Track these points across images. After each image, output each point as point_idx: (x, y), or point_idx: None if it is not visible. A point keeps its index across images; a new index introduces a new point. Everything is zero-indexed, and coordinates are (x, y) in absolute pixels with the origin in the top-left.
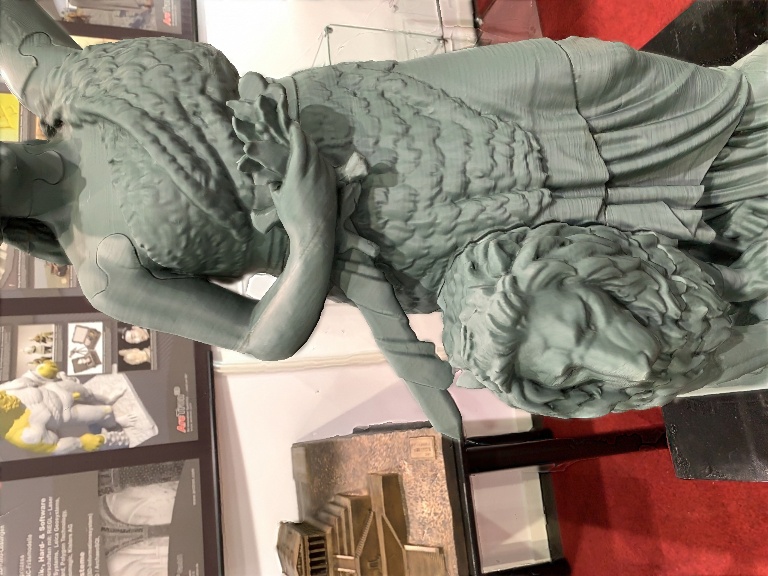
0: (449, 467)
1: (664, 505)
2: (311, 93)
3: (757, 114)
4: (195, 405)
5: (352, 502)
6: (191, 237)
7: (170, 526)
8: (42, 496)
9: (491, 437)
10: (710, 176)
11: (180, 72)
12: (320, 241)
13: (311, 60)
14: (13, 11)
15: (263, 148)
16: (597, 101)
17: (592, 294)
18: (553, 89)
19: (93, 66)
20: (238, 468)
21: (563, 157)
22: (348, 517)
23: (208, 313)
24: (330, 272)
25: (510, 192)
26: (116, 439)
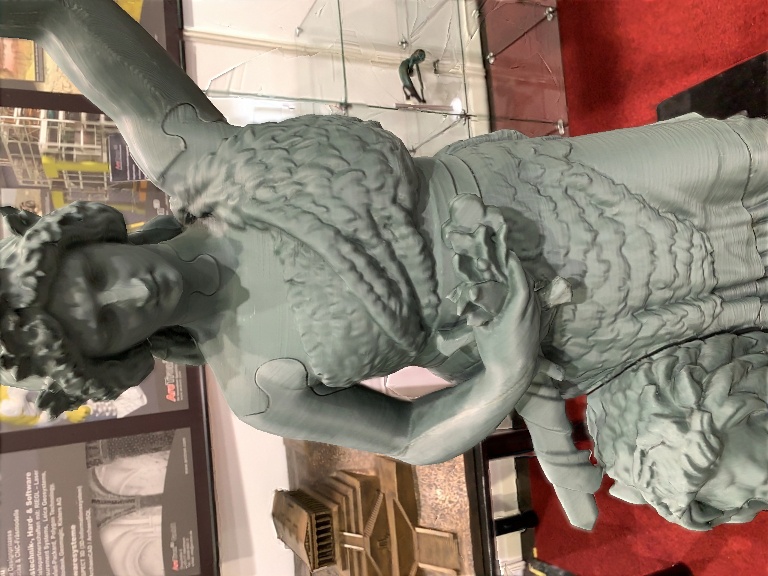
0: (468, 460)
1: None
2: (496, 191)
3: None
4: (184, 373)
5: (361, 484)
6: (374, 364)
7: (163, 496)
8: (27, 470)
9: None
10: None
11: (373, 179)
12: (526, 381)
13: (311, 1)
14: (156, 79)
15: (487, 291)
16: (760, 191)
17: None
18: (729, 184)
19: (263, 160)
20: (228, 434)
21: (728, 256)
22: (356, 497)
23: (369, 428)
24: None
25: (685, 302)
26: (103, 410)
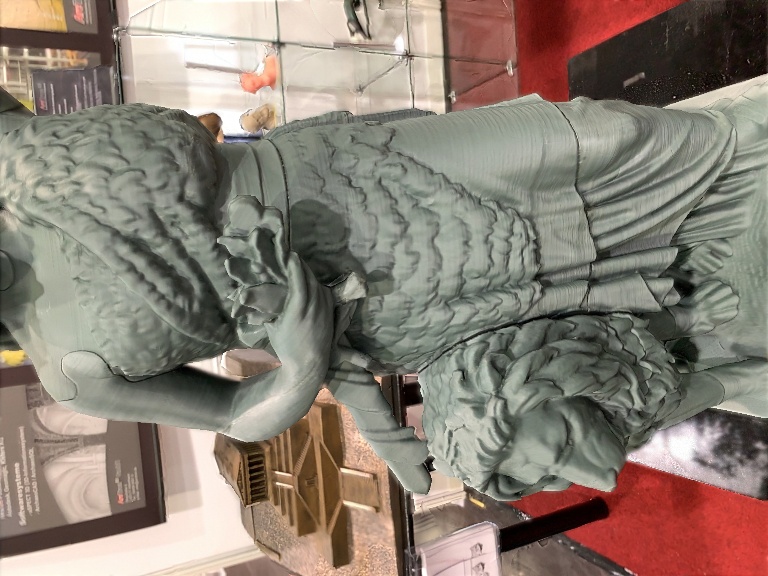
0: None
1: None
2: (302, 184)
3: (736, 162)
4: None
5: (291, 427)
6: (172, 357)
7: (106, 435)
8: None
9: None
10: (682, 224)
11: (154, 178)
12: (316, 374)
13: None
14: None
15: (260, 294)
16: (596, 176)
17: (574, 412)
18: (556, 172)
19: (42, 157)
20: None
21: (556, 242)
22: (287, 439)
23: (187, 411)
24: None
25: (503, 289)
26: None
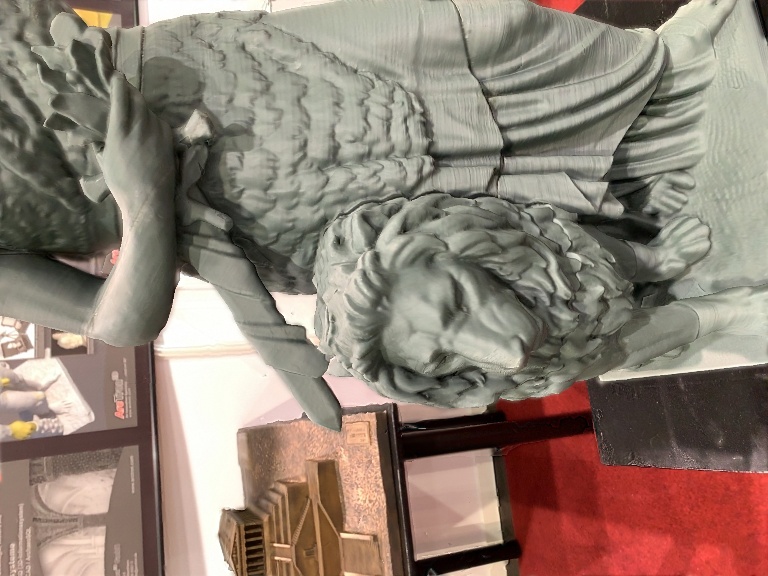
0: (384, 453)
1: (609, 487)
2: (157, 43)
3: (676, 81)
4: (134, 390)
5: (289, 489)
6: (8, 206)
7: (107, 515)
8: None
9: (443, 420)
10: (625, 147)
11: None
12: (151, 211)
13: None
14: None
15: (74, 101)
16: (492, 60)
17: (465, 272)
18: (440, 45)
19: None
20: (181, 454)
21: (451, 121)
22: (285, 505)
23: (42, 294)
24: (175, 247)
25: (387, 159)
26: (49, 426)
